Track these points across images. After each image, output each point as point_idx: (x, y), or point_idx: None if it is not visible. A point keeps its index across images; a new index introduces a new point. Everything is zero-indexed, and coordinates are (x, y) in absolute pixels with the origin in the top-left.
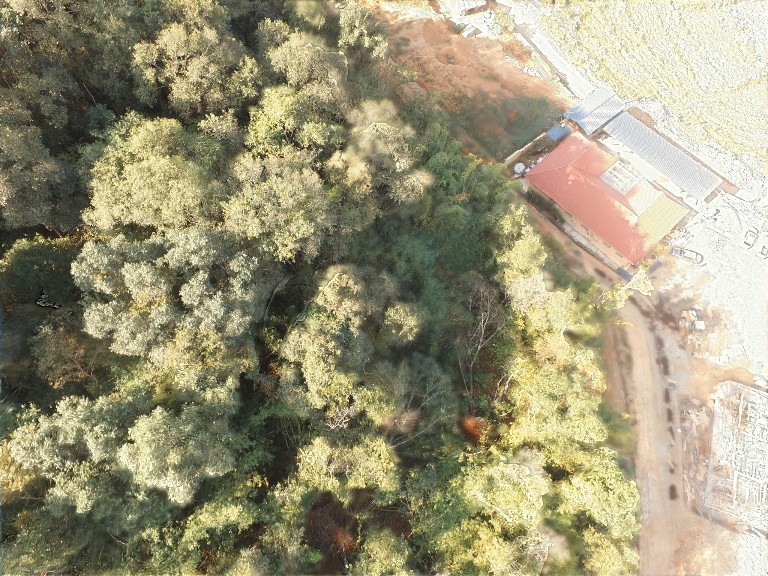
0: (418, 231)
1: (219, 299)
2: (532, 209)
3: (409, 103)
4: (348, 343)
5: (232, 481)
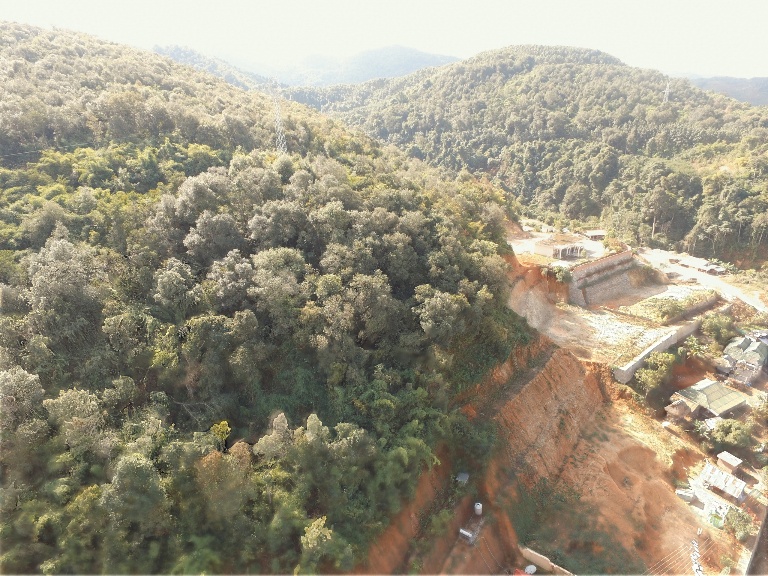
0: (324, 388)
1: (225, 280)
2: (464, 568)
3: (492, 421)
4: (220, 331)
5: (164, 322)
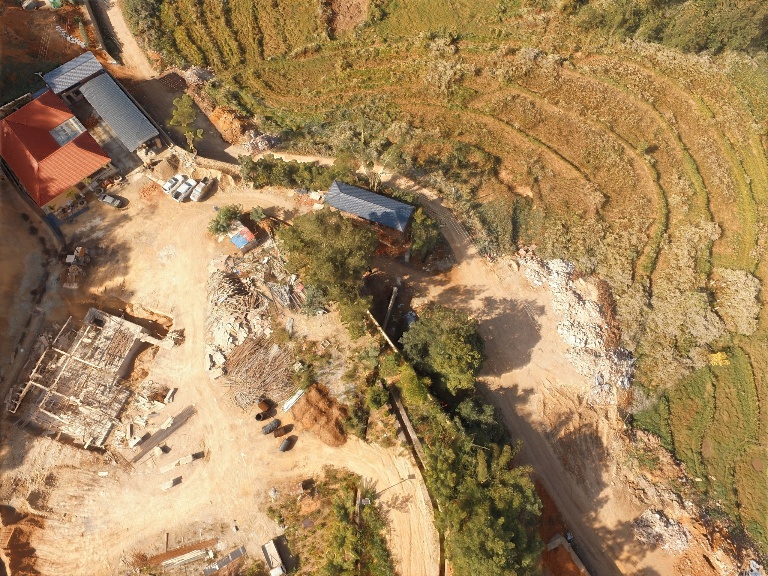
0: None
1: None
2: None
3: None
4: None
5: None
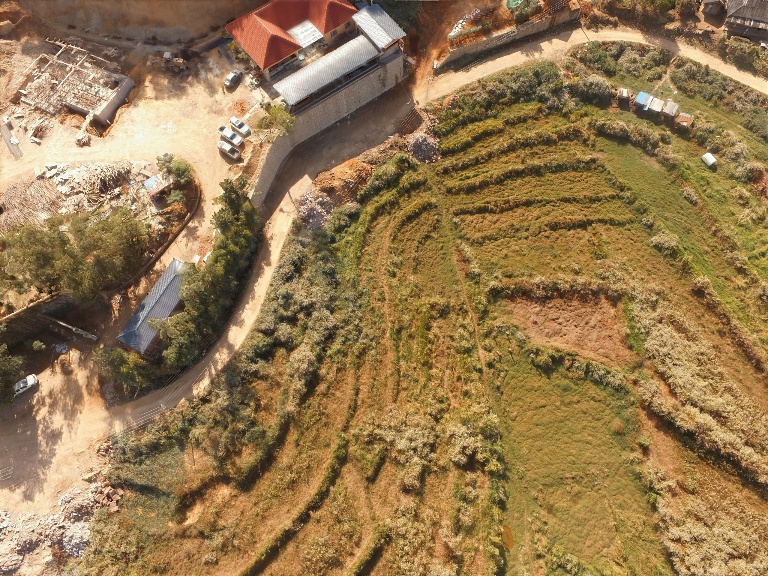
0: None
1: None
2: None
3: None
4: None
5: None
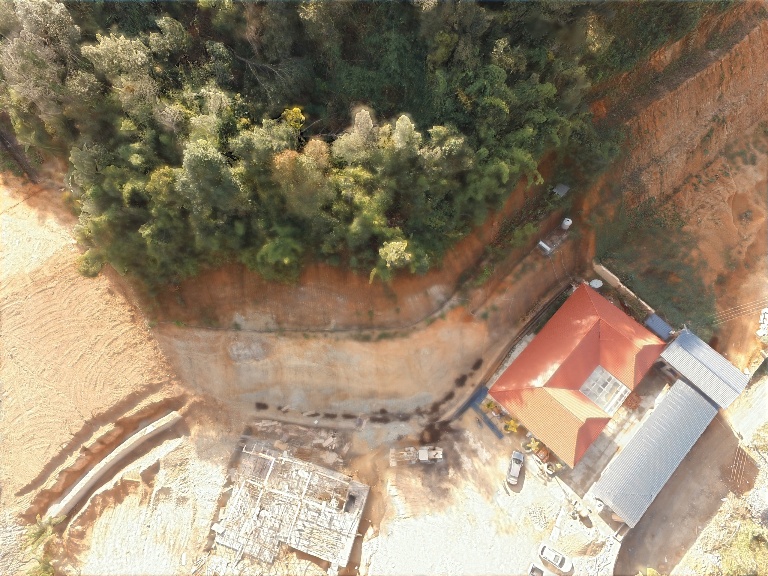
0: (422, 66)
1: None
2: (532, 276)
3: (623, 128)
4: None
5: None
